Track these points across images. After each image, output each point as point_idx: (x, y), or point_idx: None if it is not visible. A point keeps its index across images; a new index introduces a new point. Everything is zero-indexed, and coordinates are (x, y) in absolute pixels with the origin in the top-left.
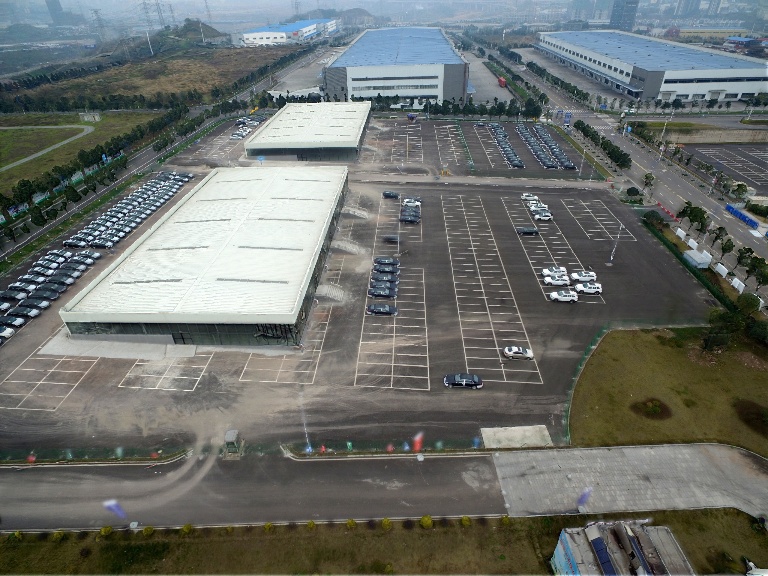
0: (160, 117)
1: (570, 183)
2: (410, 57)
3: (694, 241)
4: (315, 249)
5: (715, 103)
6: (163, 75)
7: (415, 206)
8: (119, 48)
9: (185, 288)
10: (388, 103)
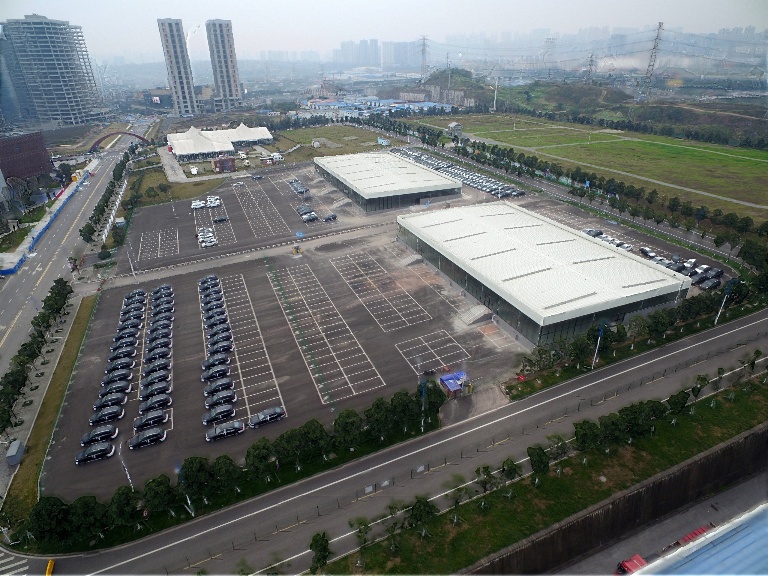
0: (703, 206)
1: (153, 277)
2: None
3: None
4: None
5: None
6: None
7: None
8: None
9: None
10: None
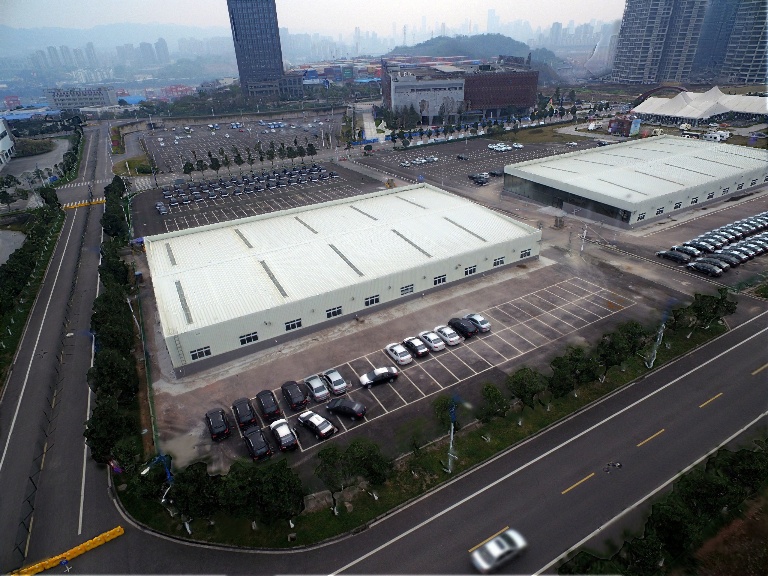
0: (682, 509)
1: (350, 166)
2: None
3: (420, 141)
4: None
5: (77, 149)
6: None
7: None
8: None
9: (718, 148)
10: None
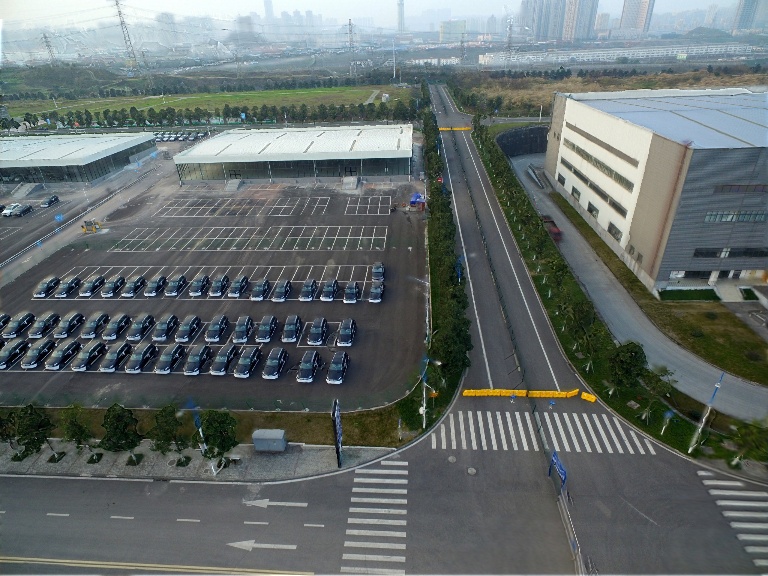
0: None
1: None
2: None
3: None
4: None
5: None
6: (600, 83)
7: None
8: None
9: None
10: None
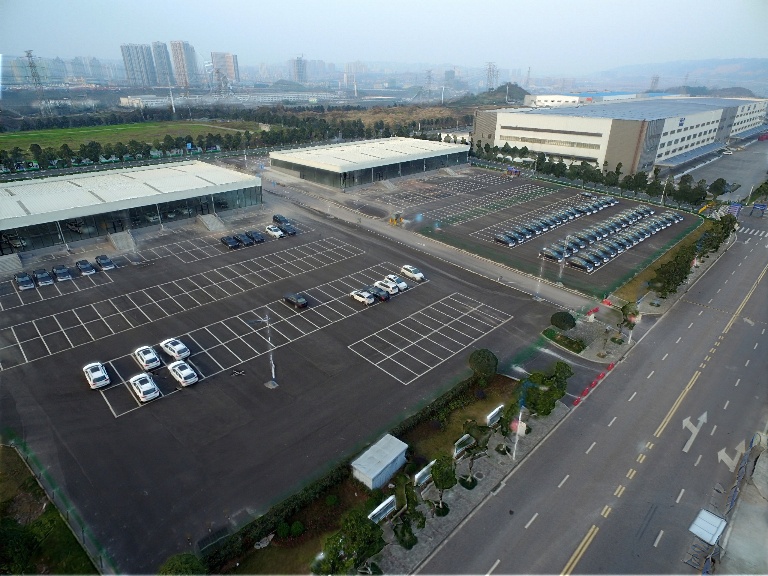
0: None
1: (532, 283)
2: (605, 113)
3: (465, 436)
4: (22, 215)
5: None
6: (386, 113)
7: (273, 235)
8: (417, 98)
9: None
10: (514, 155)
